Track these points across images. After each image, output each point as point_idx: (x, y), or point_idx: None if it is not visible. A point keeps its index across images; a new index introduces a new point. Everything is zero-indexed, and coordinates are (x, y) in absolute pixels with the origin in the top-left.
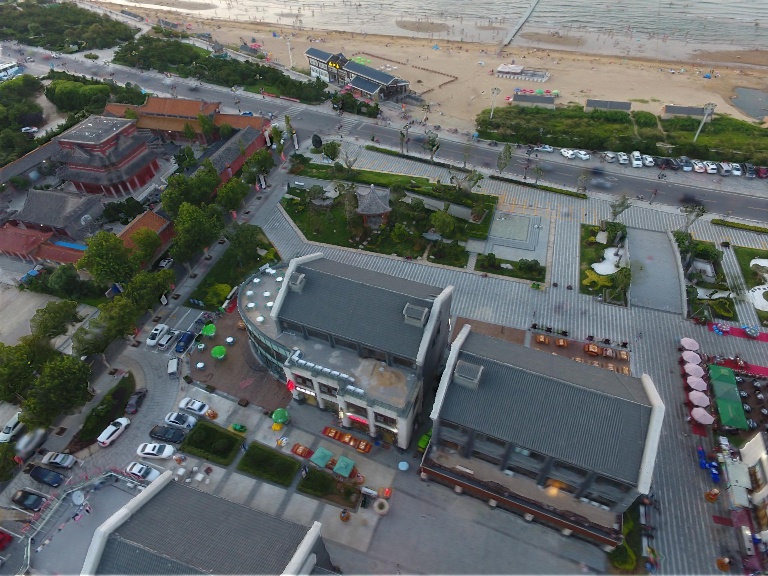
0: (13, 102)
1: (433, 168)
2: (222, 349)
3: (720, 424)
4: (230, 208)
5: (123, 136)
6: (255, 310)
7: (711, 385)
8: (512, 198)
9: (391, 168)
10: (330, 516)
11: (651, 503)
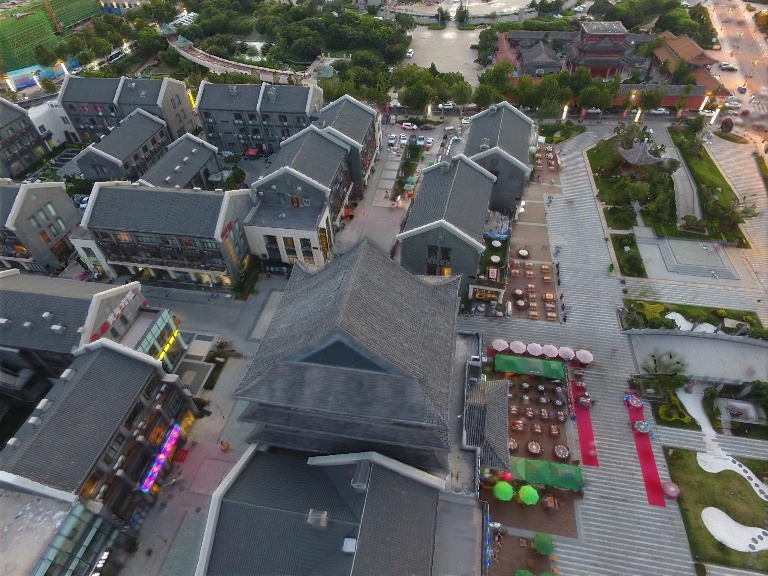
0: (634, 8)
1: (765, 202)
2: None
3: None
4: (581, 103)
5: (608, 38)
6: None
7: None
8: (759, 258)
9: (735, 176)
10: None
11: None
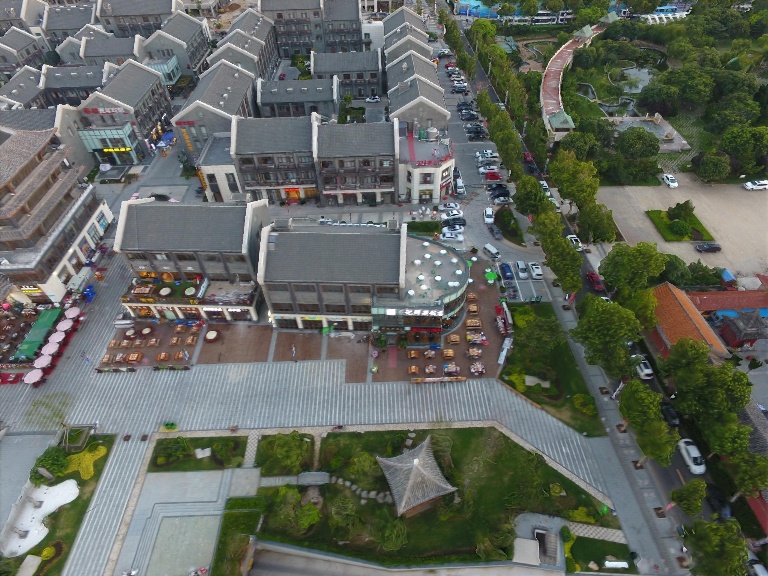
0: None
1: None
2: None
3: (62, 313)
4: None
5: None
6: None
7: (45, 339)
8: None
9: None
10: None
11: None
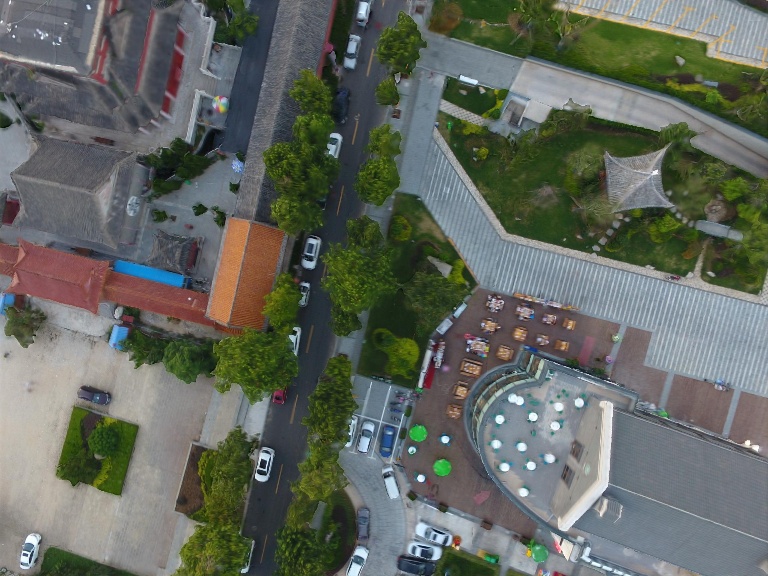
0: None
1: (716, 3)
2: (447, 468)
3: None
4: (383, 200)
5: (113, 21)
6: (509, 470)
7: None
8: None
9: (632, 5)
10: None
11: None
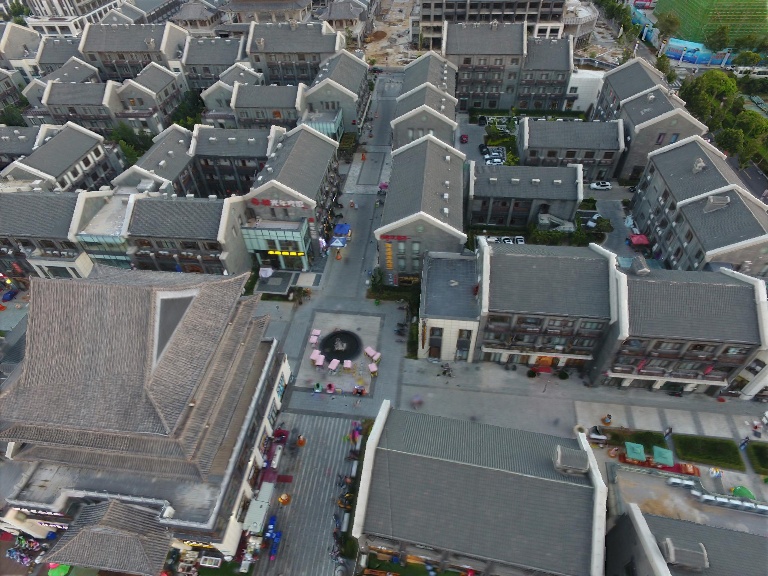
0: None
1: None
2: None
3: None
4: None
5: None
6: None
7: None
8: None
9: None
10: (619, 419)
11: (346, 478)
